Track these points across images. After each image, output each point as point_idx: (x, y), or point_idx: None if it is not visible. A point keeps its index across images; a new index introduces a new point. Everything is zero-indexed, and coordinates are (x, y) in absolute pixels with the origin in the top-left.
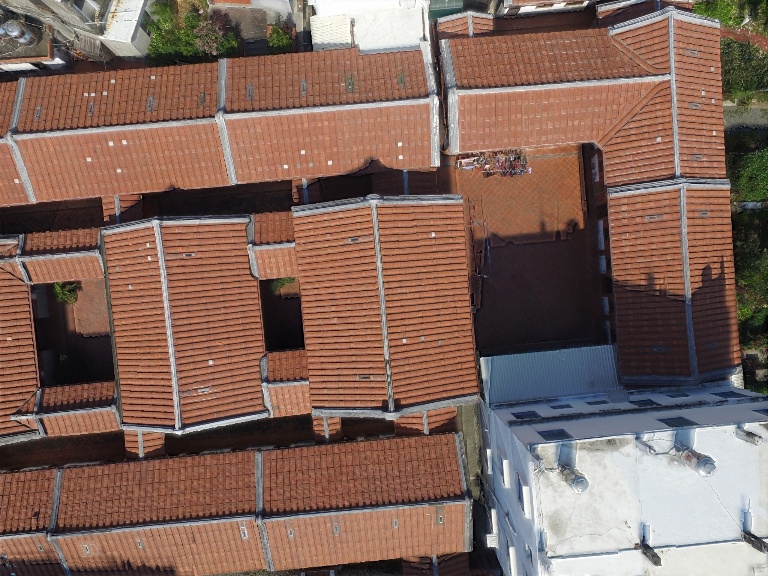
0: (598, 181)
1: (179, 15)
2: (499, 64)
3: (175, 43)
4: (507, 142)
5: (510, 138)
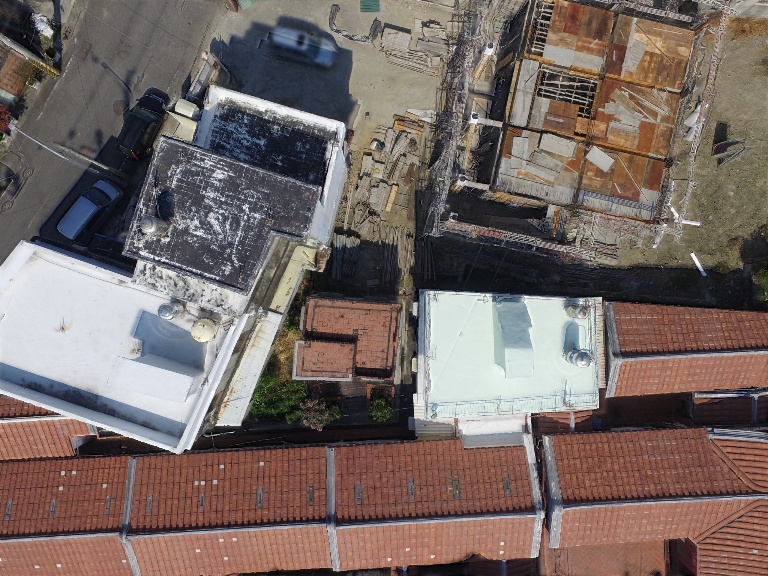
0: (683, 542)
1: (281, 371)
2: (602, 470)
3: (278, 406)
4: (606, 540)
5: (609, 537)
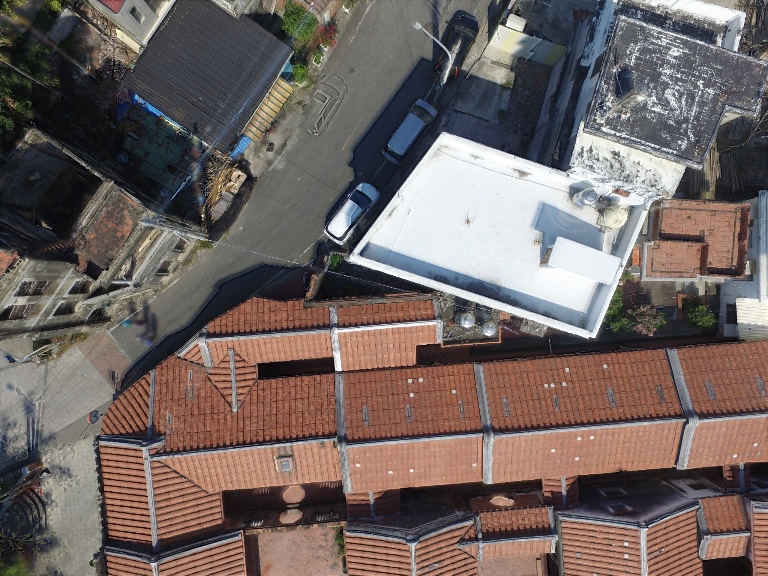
0: None
1: None
2: None
3: None
4: None
5: None
